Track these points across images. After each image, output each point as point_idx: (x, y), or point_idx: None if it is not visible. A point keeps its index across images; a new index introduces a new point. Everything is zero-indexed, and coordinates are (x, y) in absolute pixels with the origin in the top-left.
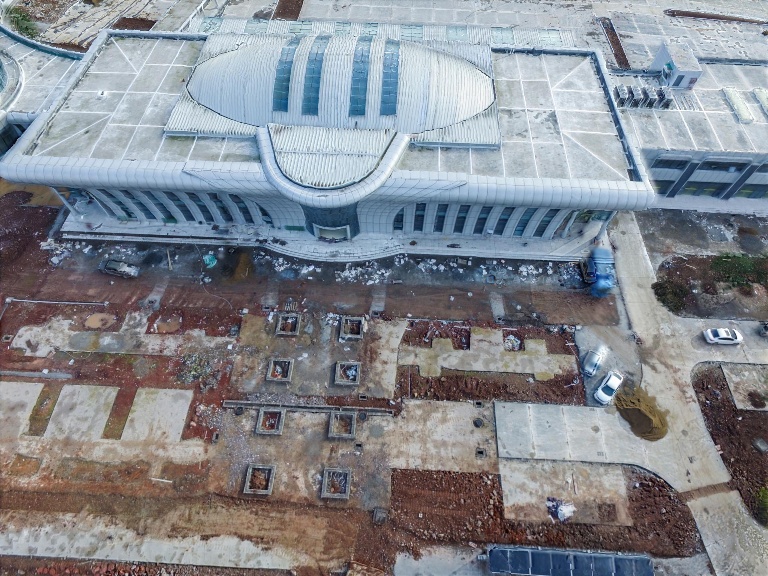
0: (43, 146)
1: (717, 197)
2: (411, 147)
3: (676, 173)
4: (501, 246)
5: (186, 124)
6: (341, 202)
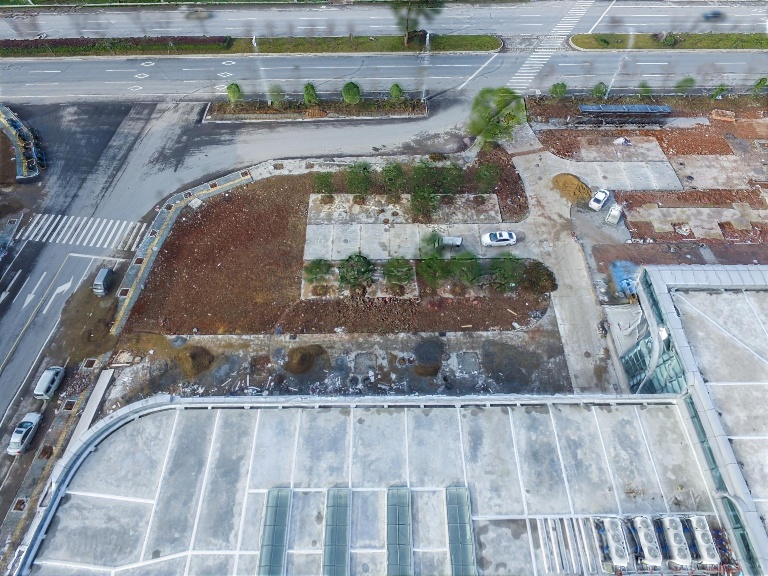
0: None
1: None
2: None
3: None
4: None
5: None
6: None
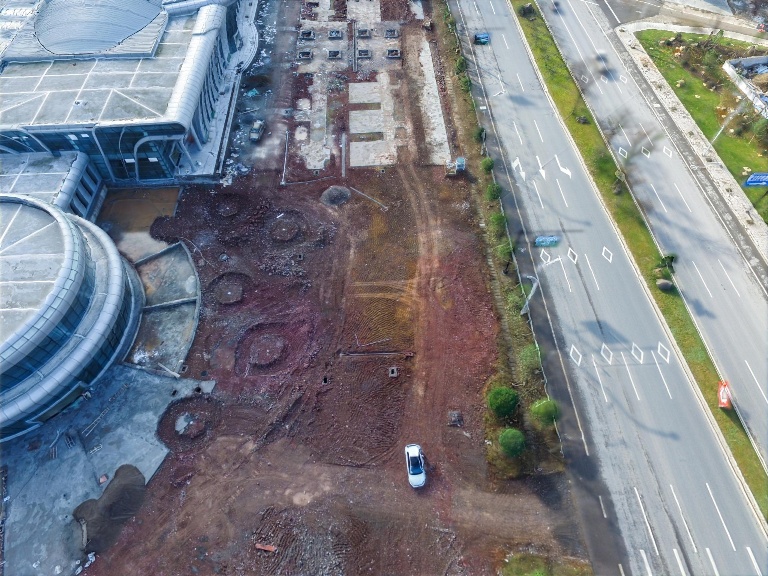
0: (150, 116)
1: None
2: None
3: None
4: None
5: (146, 43)
6: None
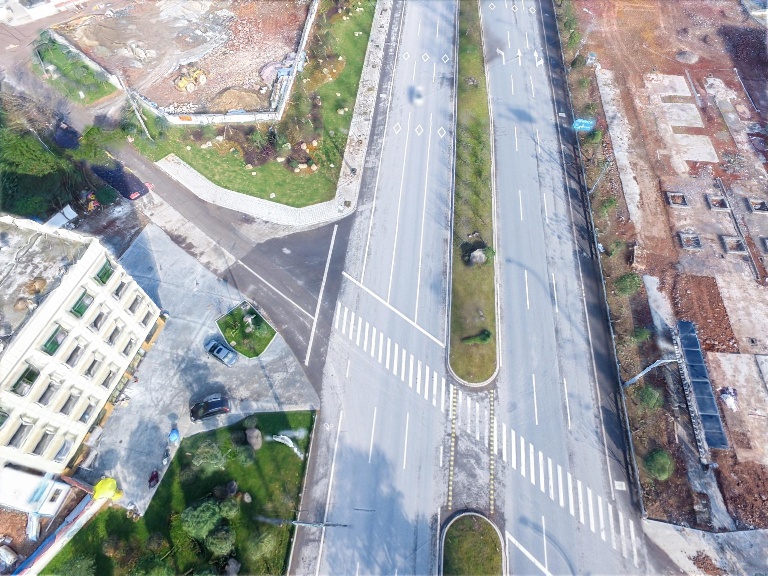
0: None
1: None
2: None
3: None
4: None
5: None
6: None
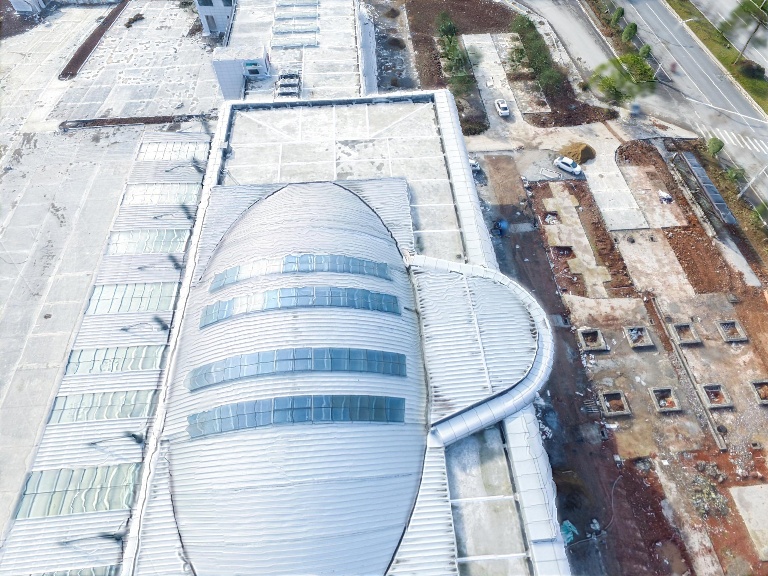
0: None
1: None
2: None
3: None
4: None
5: None
6: None
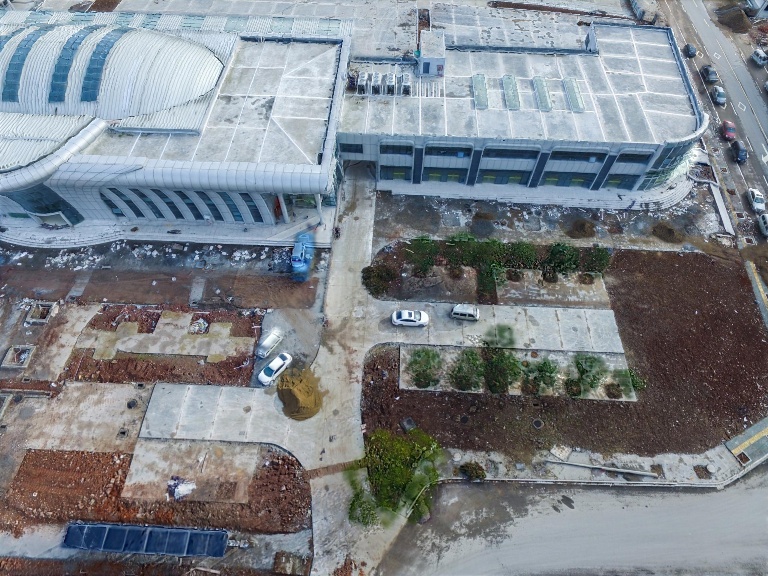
0: None
1: (463, 183)
2: (111, 133)
3: (408, 159)
4: (221, 232)
5: None
6: (4, 186)
